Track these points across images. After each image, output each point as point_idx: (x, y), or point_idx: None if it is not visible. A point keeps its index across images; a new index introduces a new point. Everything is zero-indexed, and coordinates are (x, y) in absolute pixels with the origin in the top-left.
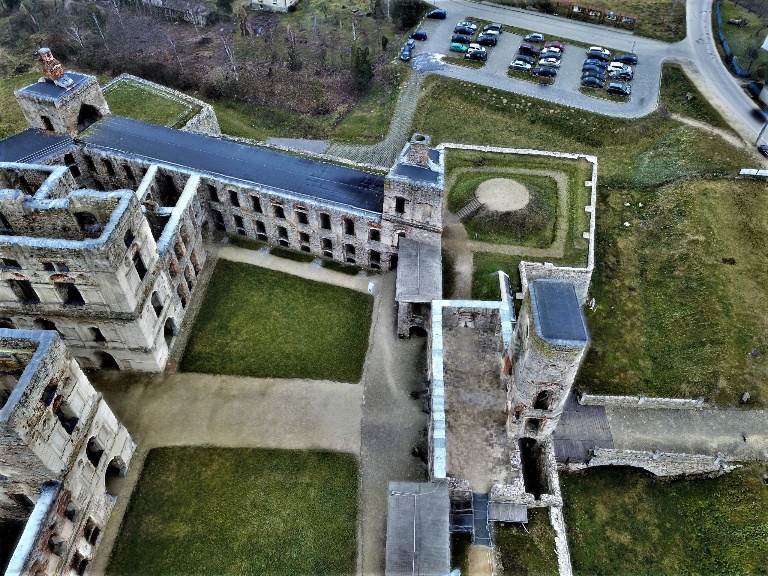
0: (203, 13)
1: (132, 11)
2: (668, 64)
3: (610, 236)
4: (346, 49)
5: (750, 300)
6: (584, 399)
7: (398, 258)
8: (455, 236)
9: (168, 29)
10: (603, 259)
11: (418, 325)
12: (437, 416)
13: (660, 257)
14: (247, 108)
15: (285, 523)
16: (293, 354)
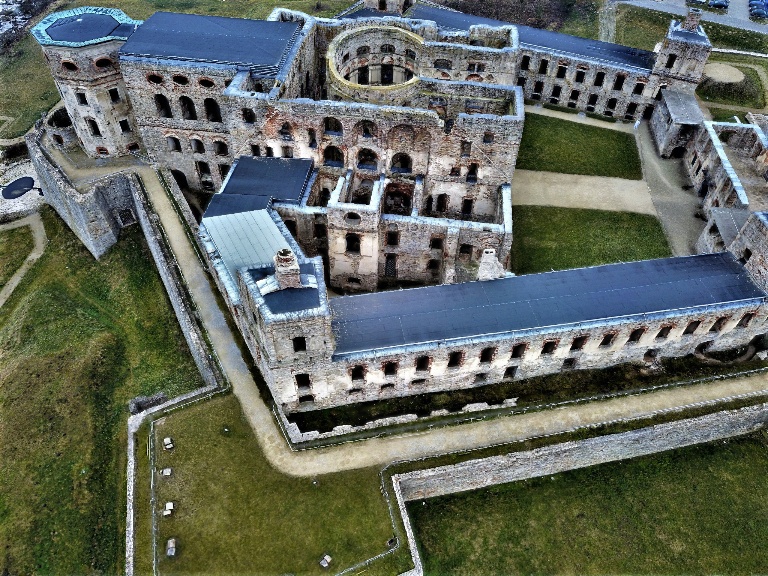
0: None
1: None
2: None
3: None
4: None
5: None
6: None
7: (666, 100)
8: None
9: None
10: None
11: (682, 145)
12: (732, 176)
13: None
14: None
15: (621, 245)
16: (588, 163)
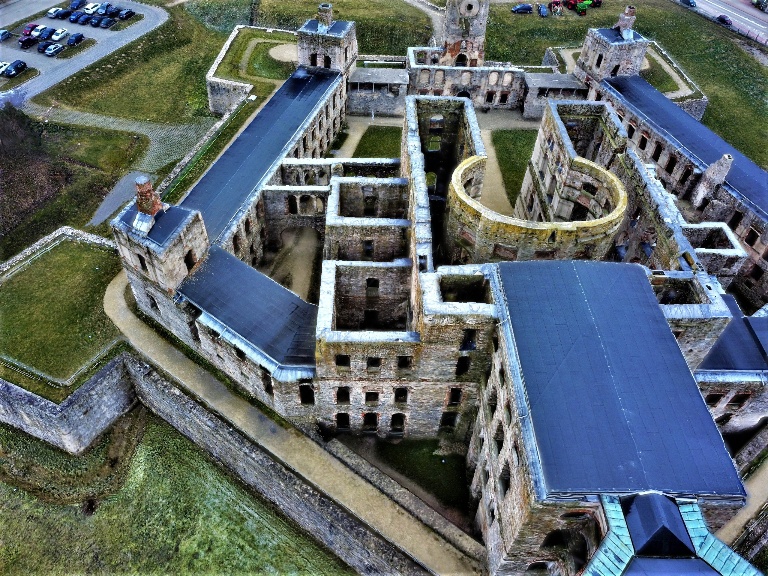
0: None
1: None
2: None
3: None
4: None
5: (366, 13)
6: None
7: (370, 81)
8: None
9: None
10: None
11: None
12: (492, 69)
13: None
14: None
15: None
16: None
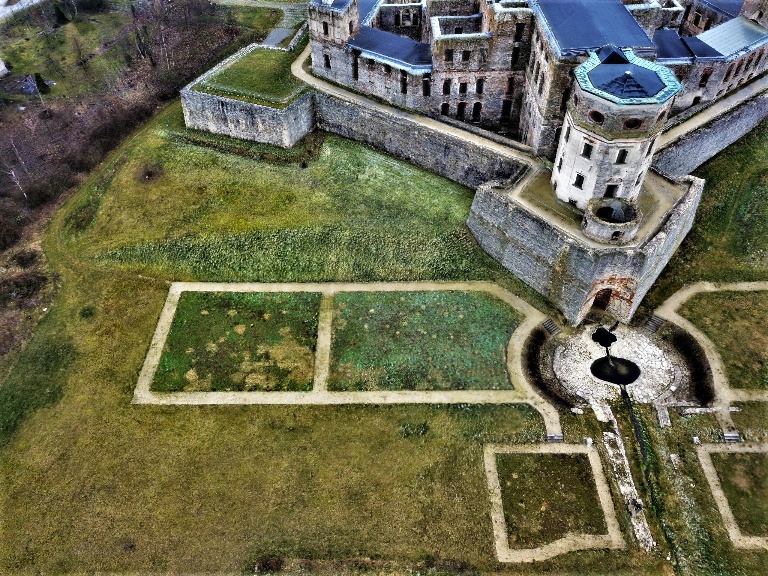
0: None
1: None
2: None
3: None
4: (122, 34)
5: None
6: None
7: None
8: None
9: None
10: None
11: None
12: None
13: None
14: None
15: None
16: None
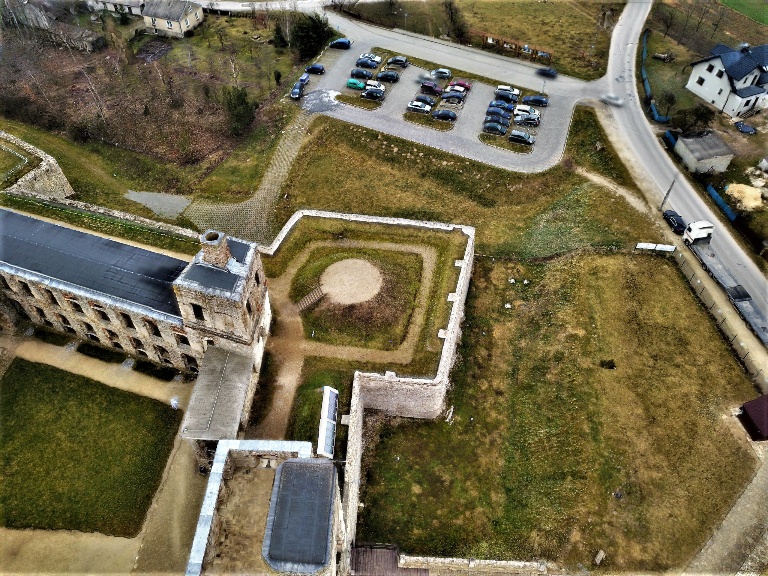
0: (88, 38)
1: (16, 34)
2: (581, 107)
3: (486, 322)
4: (237, 83)
5: (624, 418)
6: (404, 561)
7: (198, 375)
8: (288, 334)
9: (50, 56)
10: (473, 353)
11: None
12: None
13: (535, 353)
14: (113, 153)
15: None
16: (67, 494)
